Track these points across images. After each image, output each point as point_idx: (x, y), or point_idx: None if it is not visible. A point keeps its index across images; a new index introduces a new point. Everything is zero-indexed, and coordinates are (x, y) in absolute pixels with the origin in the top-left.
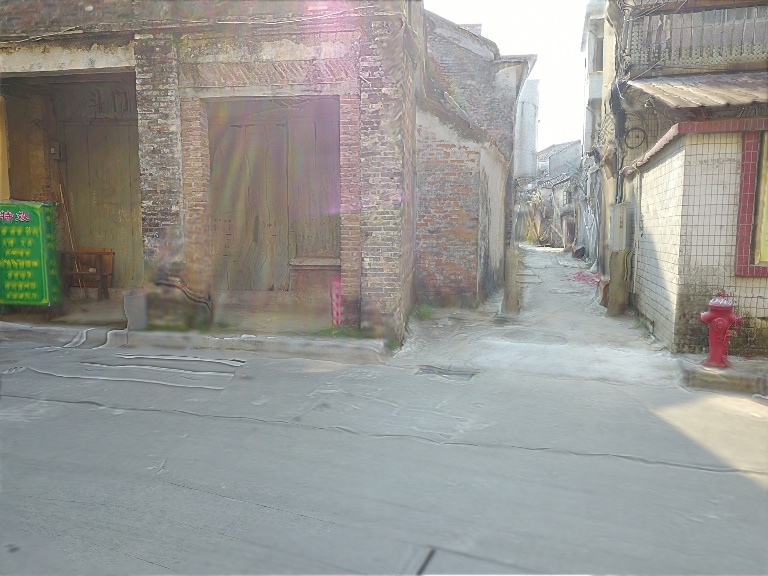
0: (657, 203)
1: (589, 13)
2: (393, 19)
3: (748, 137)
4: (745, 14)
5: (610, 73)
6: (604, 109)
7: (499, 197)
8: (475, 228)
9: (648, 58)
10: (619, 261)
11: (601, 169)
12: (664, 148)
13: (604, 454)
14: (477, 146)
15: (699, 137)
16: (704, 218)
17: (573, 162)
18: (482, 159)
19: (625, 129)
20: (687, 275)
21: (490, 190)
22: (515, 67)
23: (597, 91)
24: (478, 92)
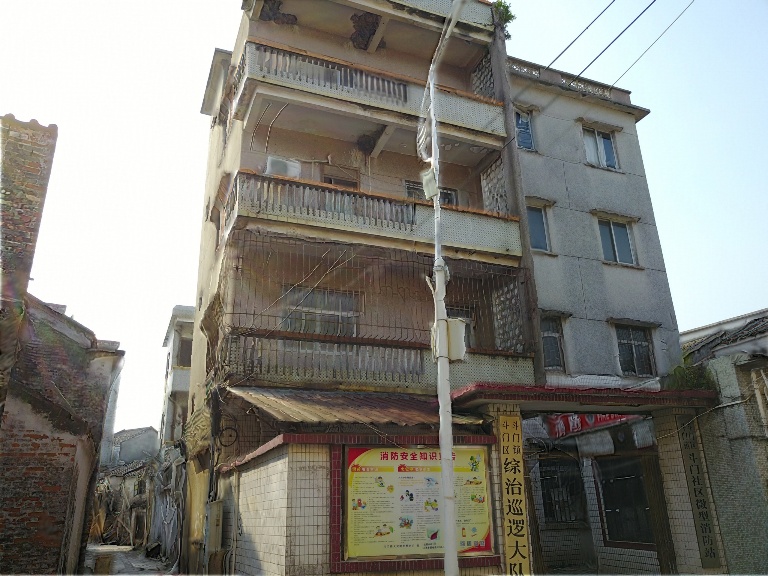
0: (259, 503)
1: (176, 315)
2: (12, 305)
3: (334, 449)
4: (313, 347)
5: (200, 373)
6: (191, 404)
7: (83, 493)
8: (59, 533)
9: (244, 370)
10: (218, 563)
11: (190, 463)
12: (266, 453)
13: None
14: (74, 438)
15: (298, 446)
16: (304, 519)
17: (145, 449)
18: (77, 453)
19: (220, 428)
20: (292, 575)
21: (78, 486)
22: (112, 357)
23: (180, 384)
24: (68, 377)
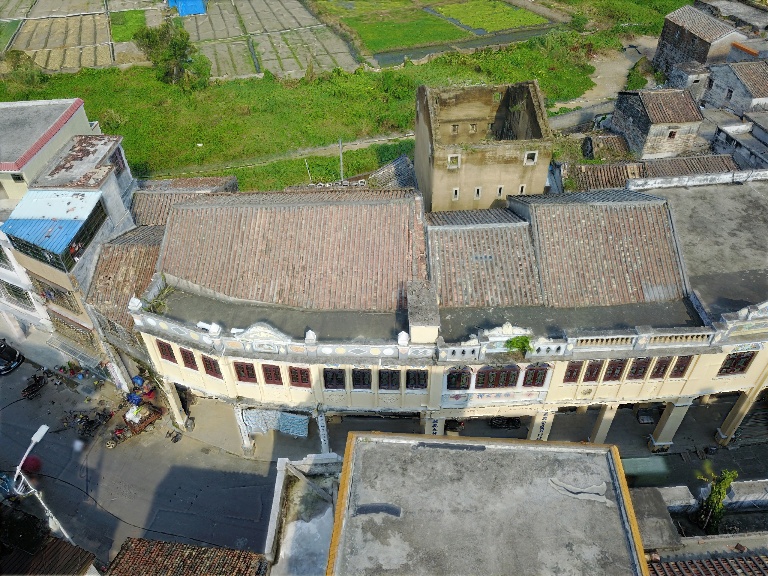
0: None
1: None
2: None
3: None
4: None
5: None
6: None
7: None
8: None
9: None
10: None
11: None
12: None
13: (158, 532)
14: None
15: None
16: None
17: None
18: None
19: None
20: None
21: None
22: None
23: None
24: None
